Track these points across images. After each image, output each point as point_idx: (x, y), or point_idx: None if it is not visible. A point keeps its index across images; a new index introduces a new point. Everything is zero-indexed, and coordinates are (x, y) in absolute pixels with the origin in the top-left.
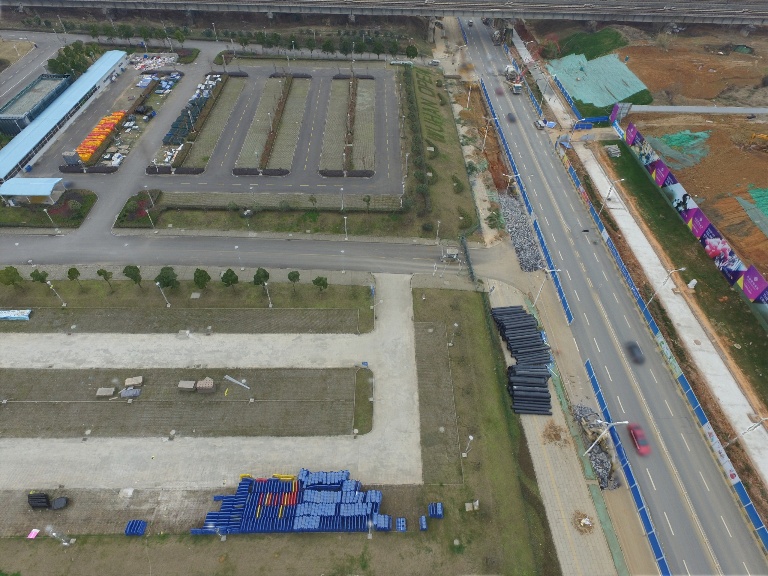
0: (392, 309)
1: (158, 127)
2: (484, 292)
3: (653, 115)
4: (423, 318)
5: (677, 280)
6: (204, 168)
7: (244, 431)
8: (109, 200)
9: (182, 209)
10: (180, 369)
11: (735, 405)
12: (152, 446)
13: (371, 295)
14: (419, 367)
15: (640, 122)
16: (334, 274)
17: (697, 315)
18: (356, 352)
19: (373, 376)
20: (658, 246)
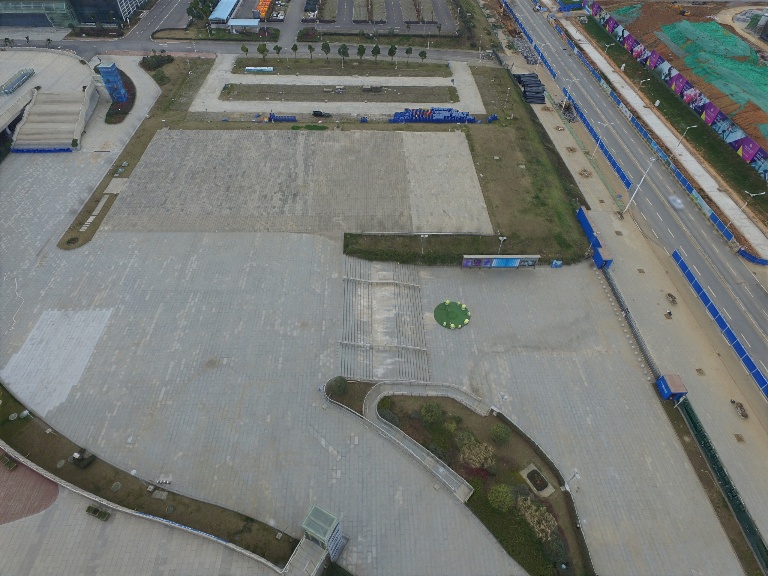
0: (460, 71)
1: (296, 4)
2: (508, 69)
3: (610, 2)
4: (477, 73)
5: (615, 67)
6: (335, 21)
7: (399, 101)
8: (287, 32)
9: (332, 35)
10: (359, 86)
11: (637, 104)
12: (358, 104)
13: (448, 66)
14: (478, 86)
15: (602, 6)
16: (426, 60)
17: (624, 78)
18: (445, 82)
19: (456, 88)
20: (606, 56)
